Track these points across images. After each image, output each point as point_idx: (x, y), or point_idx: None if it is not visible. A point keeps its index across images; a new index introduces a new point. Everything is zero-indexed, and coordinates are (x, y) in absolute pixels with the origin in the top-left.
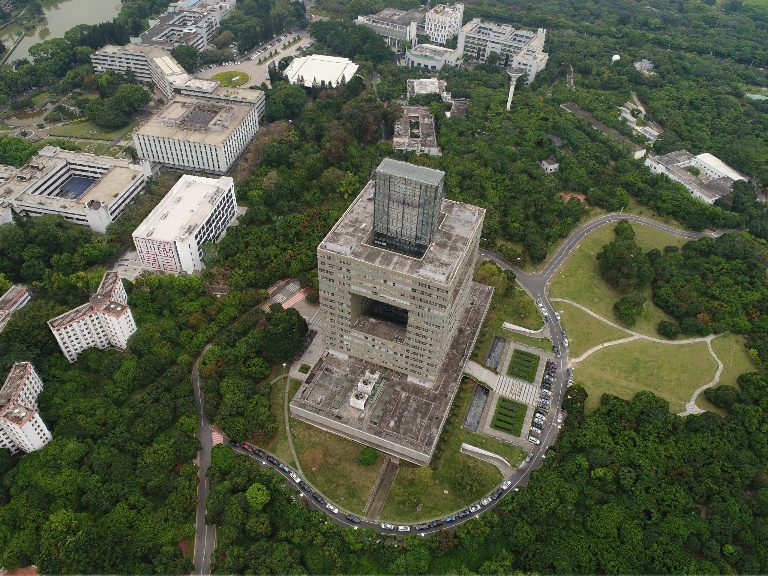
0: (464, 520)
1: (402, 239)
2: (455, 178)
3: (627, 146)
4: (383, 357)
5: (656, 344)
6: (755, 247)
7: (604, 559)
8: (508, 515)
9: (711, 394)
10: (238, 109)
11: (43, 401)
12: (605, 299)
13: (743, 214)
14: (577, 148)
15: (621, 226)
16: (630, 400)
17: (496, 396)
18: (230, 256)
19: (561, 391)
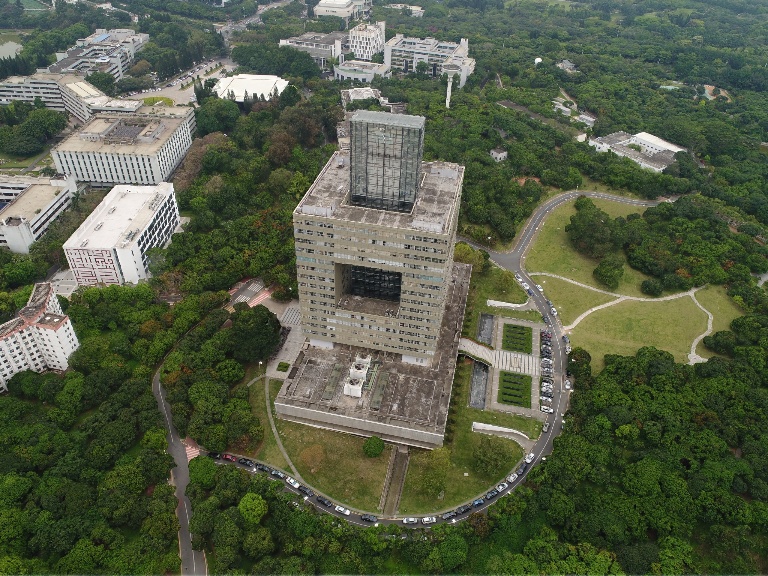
0: (493, 501)
1: (384, 199)
2: None
3: (569, 131)
4: (374, 337)
5: (643, 303)
6: (712, 206)
7: (654, 517)
8: (541, 487)
9: (711, 341)
10: (168, 122)
11: None
12: (582, 268)
13: (692, 179)
14: (522, 136)
15: (581, 201)
16: None
17: (496, 371)
18: (179, 262)
19: (561, 358)
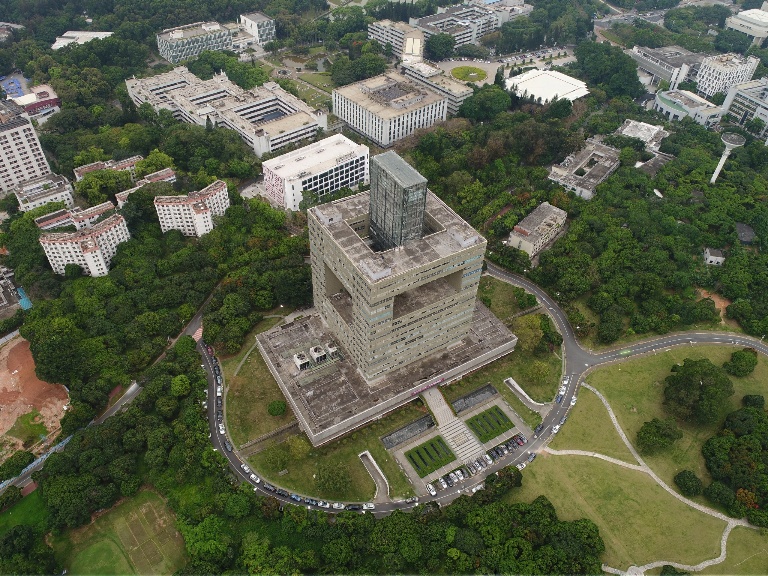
0: (306, 507)
1: (385, 233)
2: (581, 225)
3: None
4: (342, 336)
5: (659, 489)
6: None
7: None
8: (338, 526)
9: (666, 573)
10: (431, 96)
11: (119, 248)
12: (645, 414)
13: None
14: (764, 251)
15: (740, 353)
16: (570, 520)
17: (436, 433)
18: None
19: None
